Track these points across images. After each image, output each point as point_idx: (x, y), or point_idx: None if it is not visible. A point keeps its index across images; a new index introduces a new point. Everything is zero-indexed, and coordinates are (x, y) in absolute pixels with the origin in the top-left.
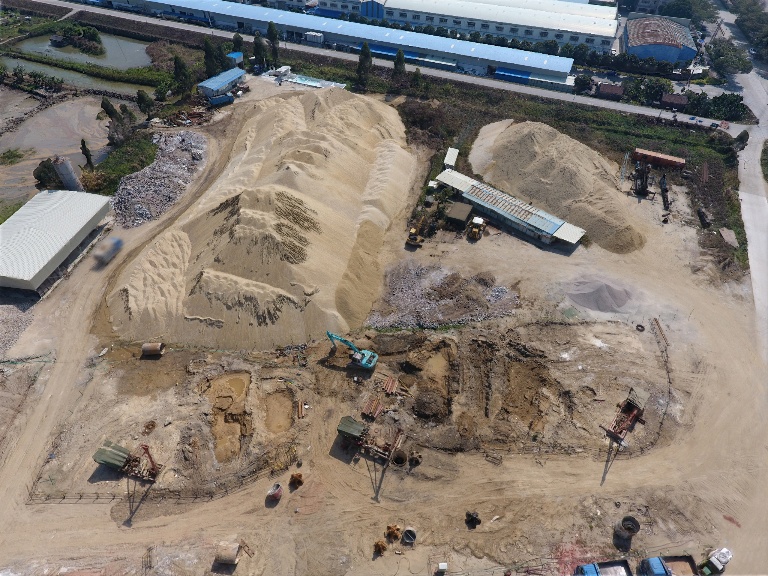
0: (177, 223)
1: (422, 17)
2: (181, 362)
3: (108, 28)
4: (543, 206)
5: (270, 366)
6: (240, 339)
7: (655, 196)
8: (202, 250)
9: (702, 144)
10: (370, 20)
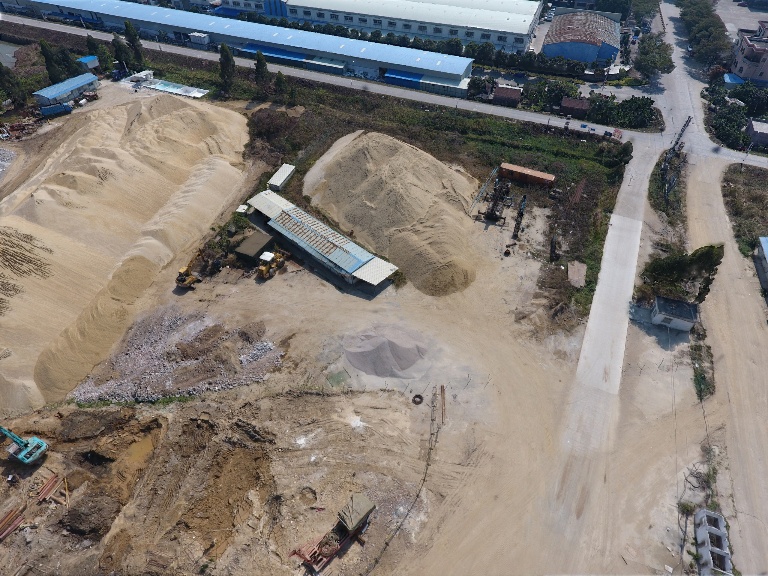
0: None
1: (326, 15)
2: None
3: None
4: (365, 235)
5: None
6: None
7: (508, 221)
8: None
9: None
10: None
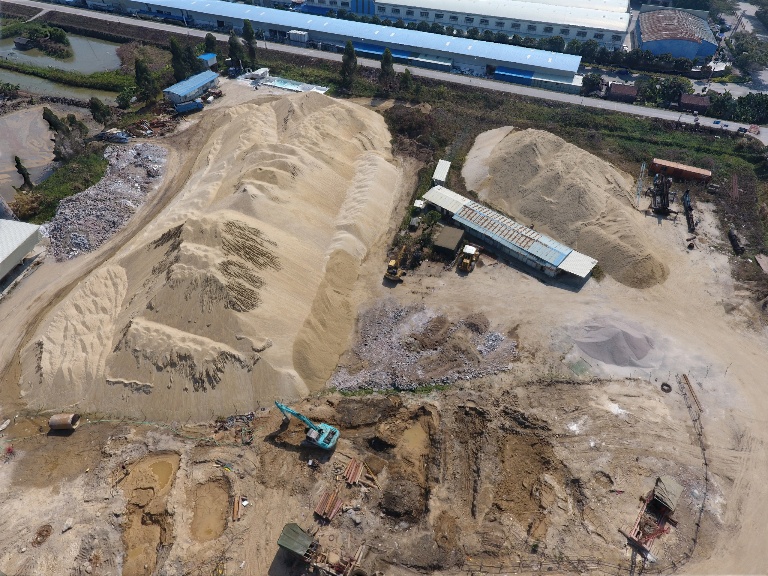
0: (118, 255)
1: (416, 13)
2: (97, 439)
3: (79, 29)
4: (547, 229)
5: (206, 444)
6: (172, 408)
7: (677, 215)
8: (137, 292)
9: (729, 152)
10: (360, 17)
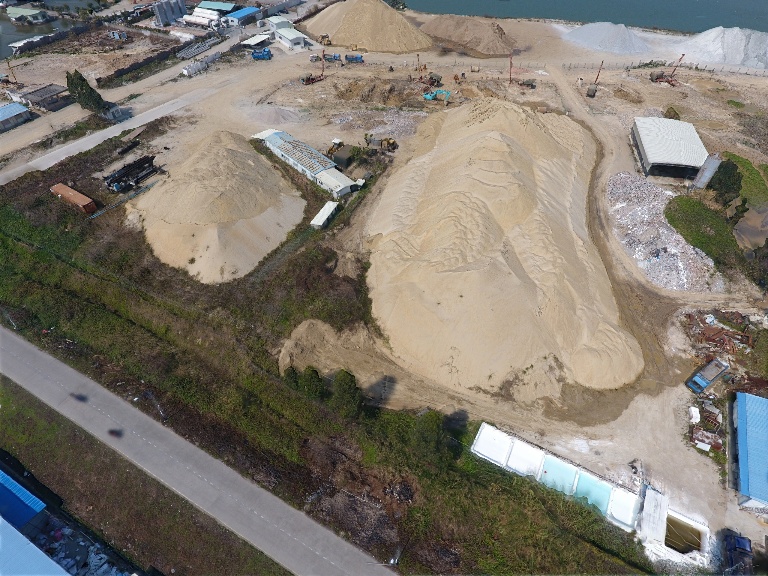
0: (585, 166)
1: None
2: None
3: None
4: (264, 162)
5: None
6: None
7: None
8: None
9: None
10: None
